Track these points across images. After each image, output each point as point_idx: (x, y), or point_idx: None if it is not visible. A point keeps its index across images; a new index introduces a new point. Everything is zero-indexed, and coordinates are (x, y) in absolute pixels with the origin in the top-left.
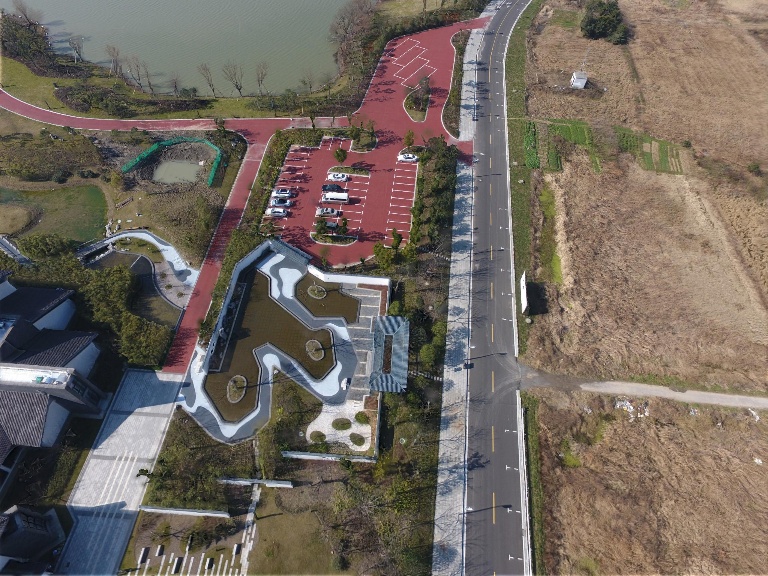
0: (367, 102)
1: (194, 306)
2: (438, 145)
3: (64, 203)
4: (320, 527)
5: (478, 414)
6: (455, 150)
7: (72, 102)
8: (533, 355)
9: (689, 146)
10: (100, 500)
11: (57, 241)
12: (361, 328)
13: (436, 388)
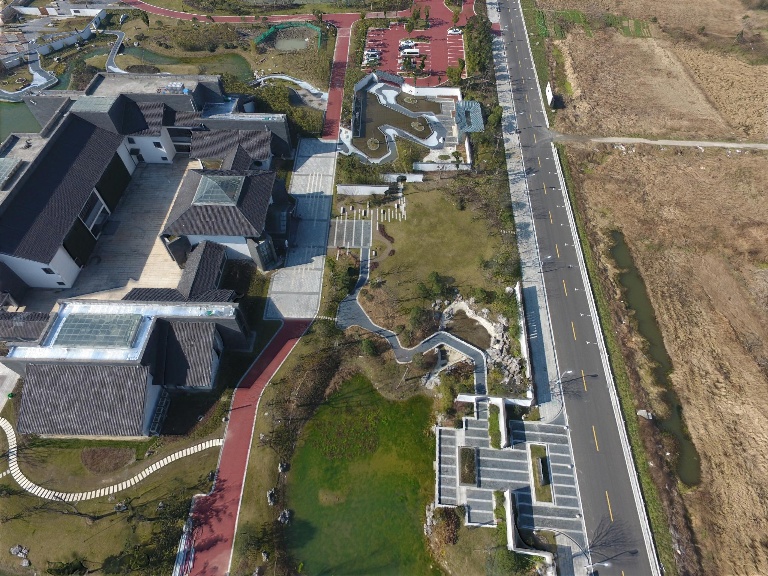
0: (417, 2)
1: (331, 109)
2: (477, 20)
3: (218, 63)
4: (444, 196)
5: (528, 152)
6: (490, 23)
7: (199, 7)
8: (559, 126)
9: (656, 21)
10: (307, 191)
11: (230, 75)
12: (445, 116)
13: (500, 141)
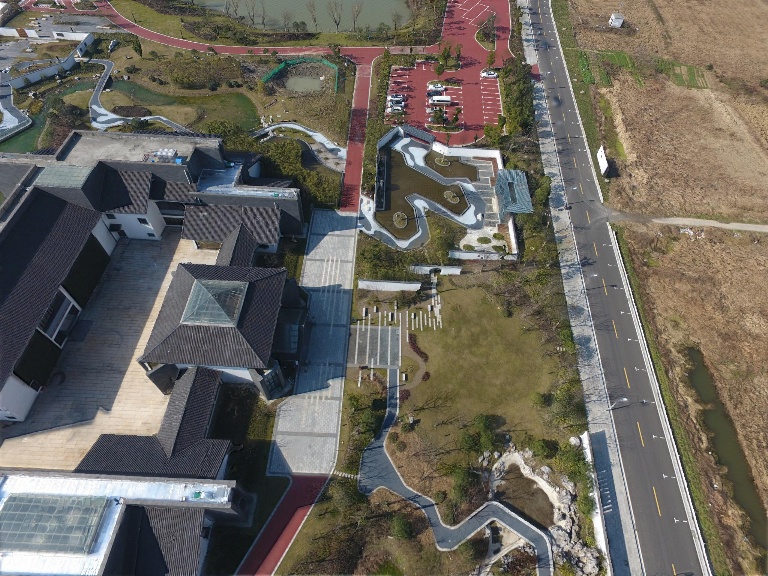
0: (445, 36)
1: (350, 171)
2: (515, 63)
3: (220, 105)
4: (486, 295)
5: (581, 235)
6: (529, 67)
7: (200, 33)
8: (614, 201)
9: (711, 69)
10: (322, 283)
11: (233, 125)
12: (483, 184)
13: (548, 220)
